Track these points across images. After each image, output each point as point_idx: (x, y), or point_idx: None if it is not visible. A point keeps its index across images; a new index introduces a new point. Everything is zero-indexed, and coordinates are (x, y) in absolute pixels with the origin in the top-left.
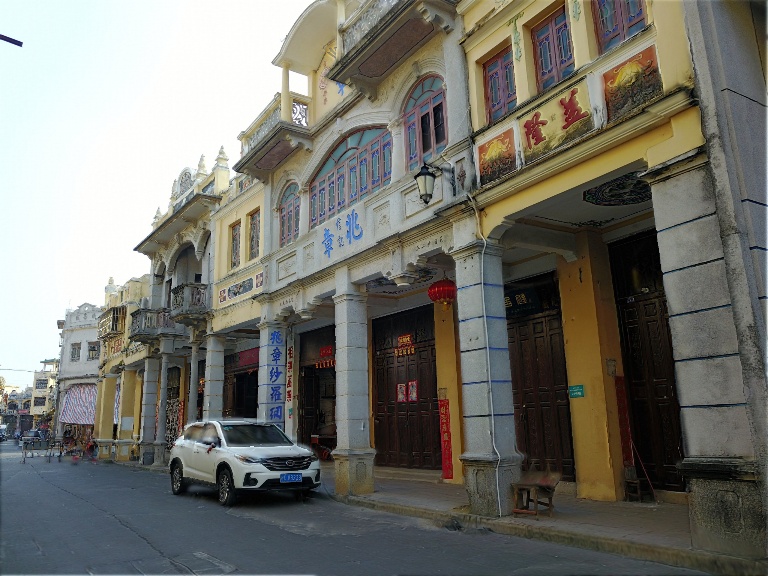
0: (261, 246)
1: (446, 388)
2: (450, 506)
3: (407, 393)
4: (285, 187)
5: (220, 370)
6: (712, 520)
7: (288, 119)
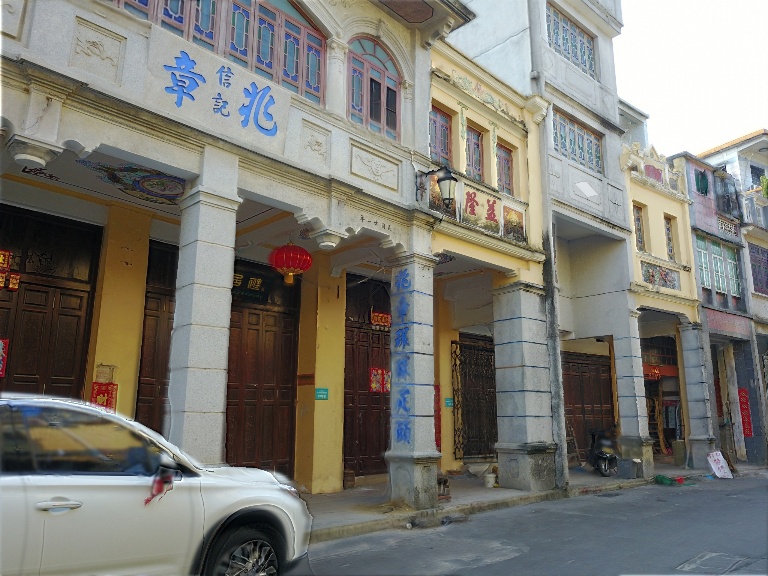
0: None
1: (116, 366)
2: (357, 515)
3: None
4: None
5: None
6: (537, 475)
7: None
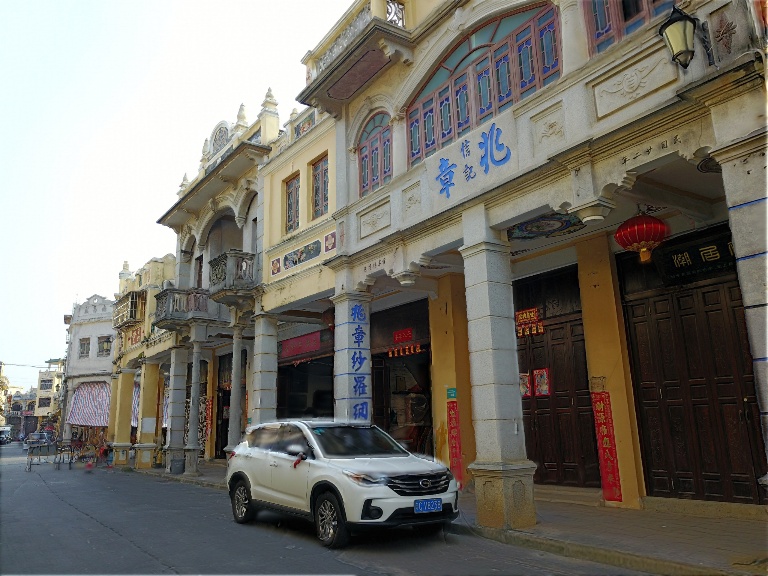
0: (331, 199)
1: (604, 376)
2: (711, 556)
3: (532, 385)
4: (366, 120)
5: (272, 359)
6: None
7: (383, 18)
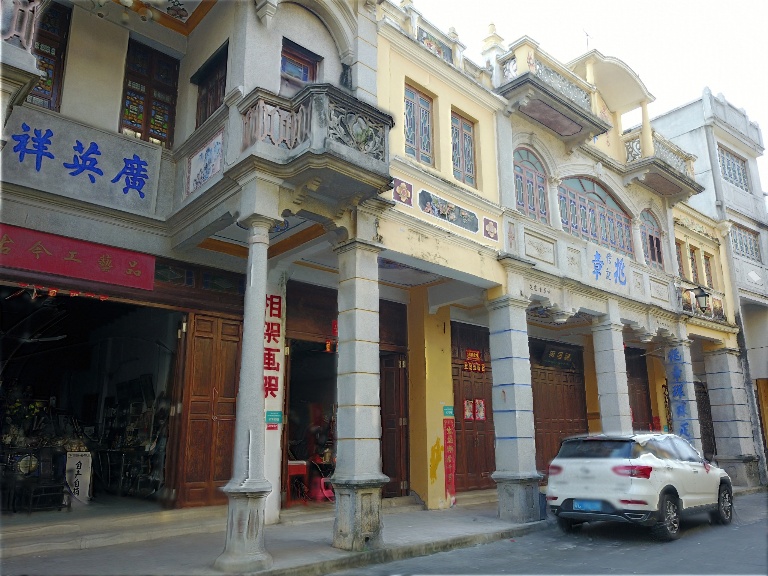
0: (488, 182)
1: None
2: None
3: (475, 411)
4: (522, 145)
5: None
6: None
7: None
